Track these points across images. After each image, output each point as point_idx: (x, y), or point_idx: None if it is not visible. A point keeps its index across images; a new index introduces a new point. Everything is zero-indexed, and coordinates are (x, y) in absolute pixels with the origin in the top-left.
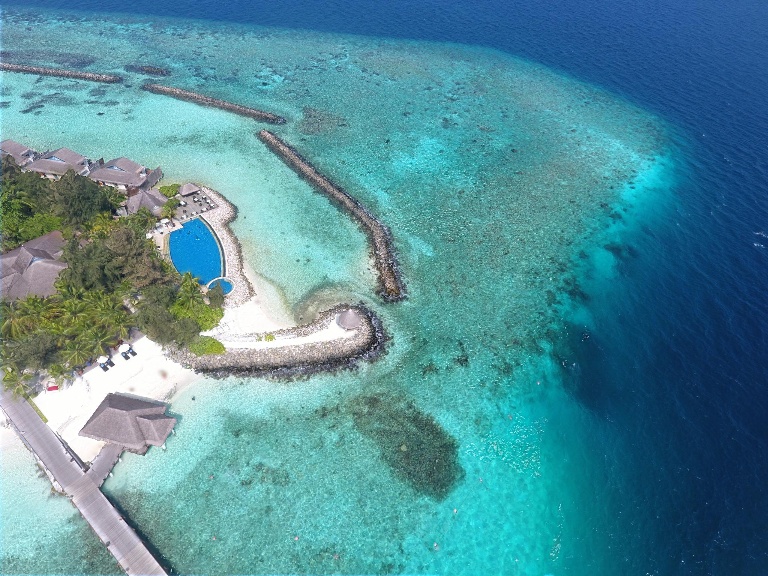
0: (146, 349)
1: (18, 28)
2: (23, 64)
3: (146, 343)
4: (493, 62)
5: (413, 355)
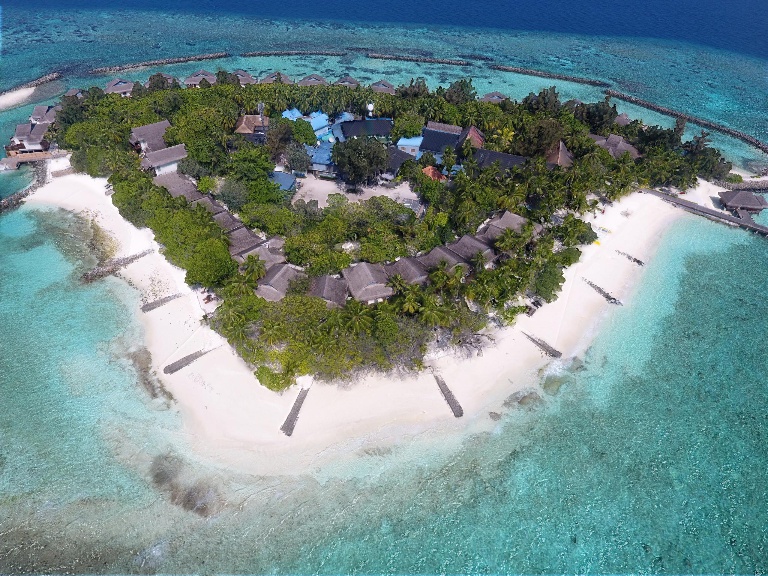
0: None
1: (346, 33)
2: None
3: None
4: (694, 49)
5: None
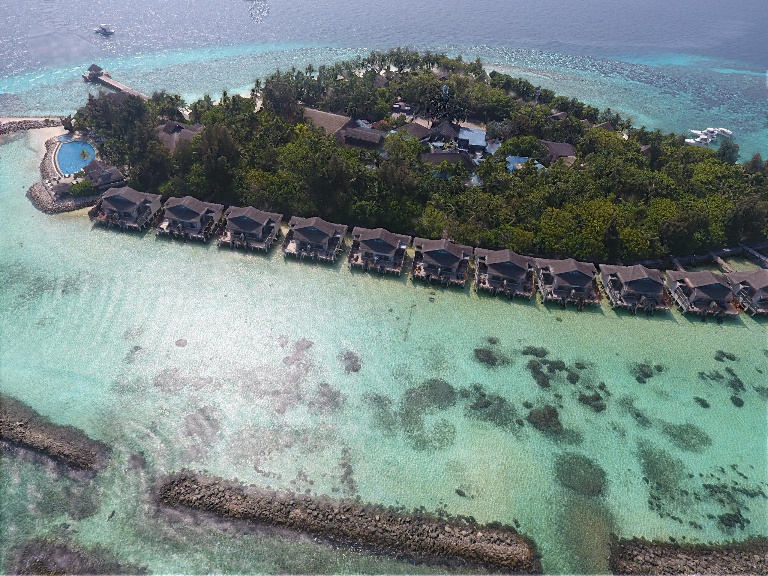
0: None
1: None
2: (443, 574)
3: None
4: None
5: None
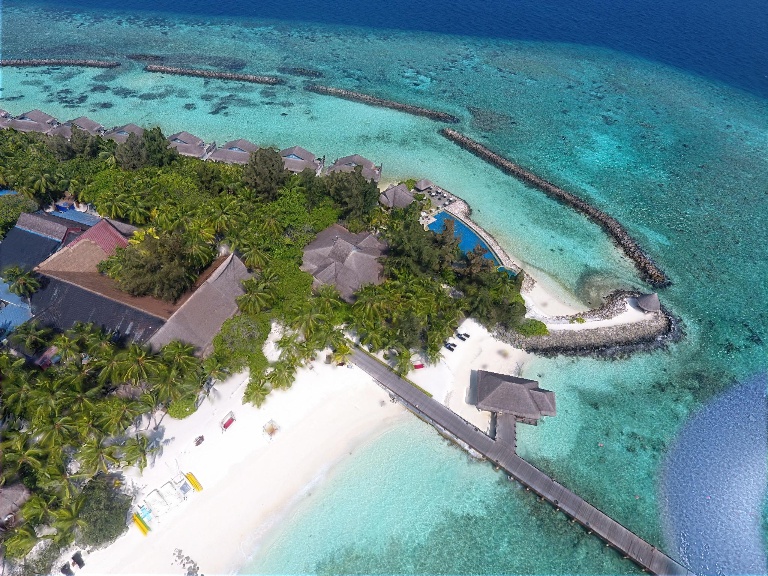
0: (474, 331)
1: (154, 33)
2: (182, 67)
3: (471, 326)
4: (614, 61)
5: (708, 336)
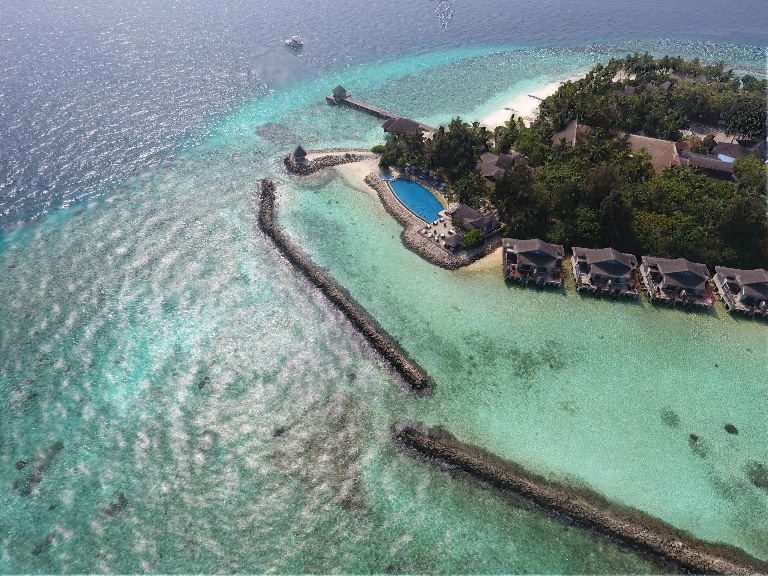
0: None
1: None
2: None
3: None
4: None
5: None
